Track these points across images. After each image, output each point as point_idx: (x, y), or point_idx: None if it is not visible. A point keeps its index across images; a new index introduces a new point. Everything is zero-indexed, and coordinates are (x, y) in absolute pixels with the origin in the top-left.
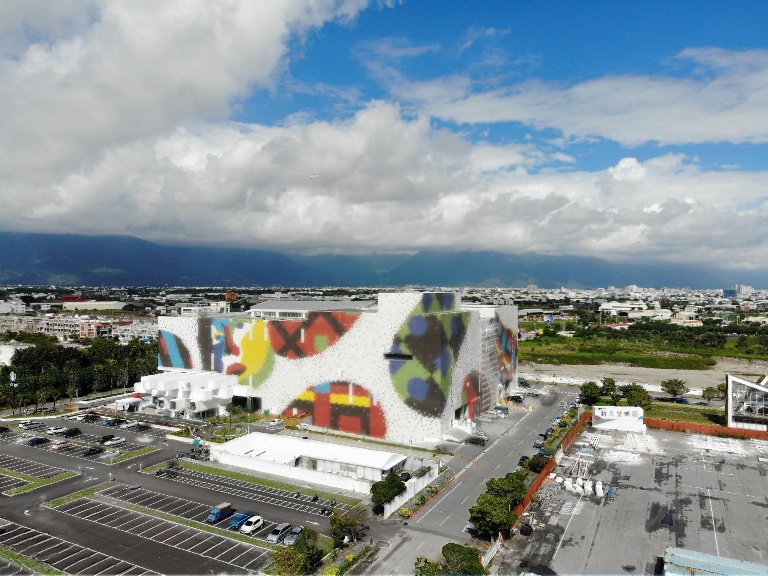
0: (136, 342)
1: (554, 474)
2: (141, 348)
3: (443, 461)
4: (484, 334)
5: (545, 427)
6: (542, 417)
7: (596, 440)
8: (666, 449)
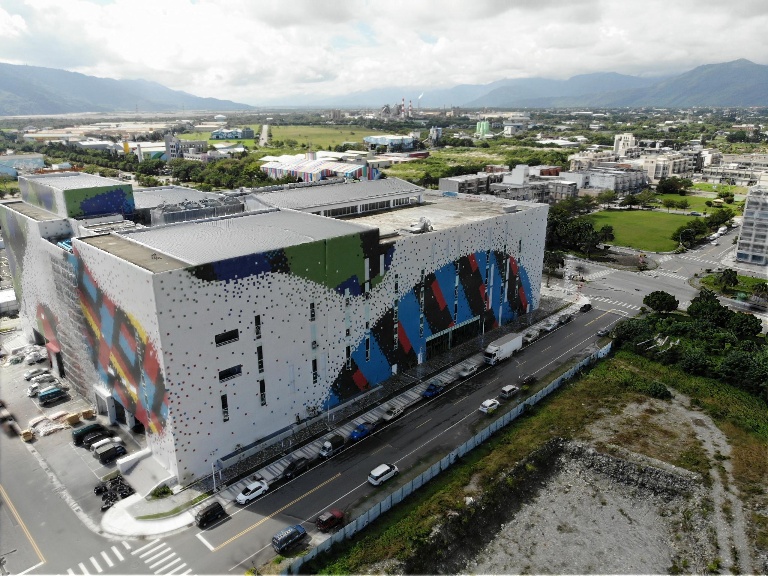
0: (699, 224)
1: None
2: (559, 223)
3: None
4: (57, 269)
5: None
6: None
7: None
8: None
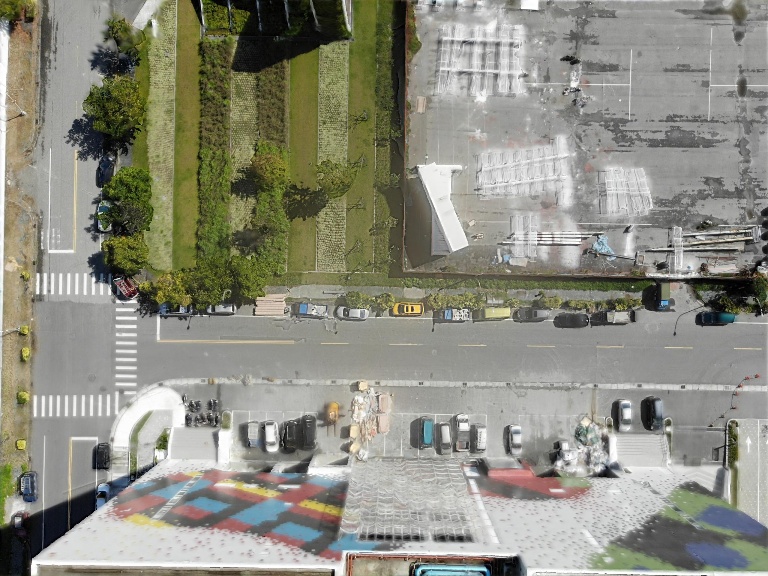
0: None
1: (764, 269)
2: None
3: (765, 427)
4: None
5: (492, 332)
6: (415, 352)
7: (559, 237)
8: (540, 134)
